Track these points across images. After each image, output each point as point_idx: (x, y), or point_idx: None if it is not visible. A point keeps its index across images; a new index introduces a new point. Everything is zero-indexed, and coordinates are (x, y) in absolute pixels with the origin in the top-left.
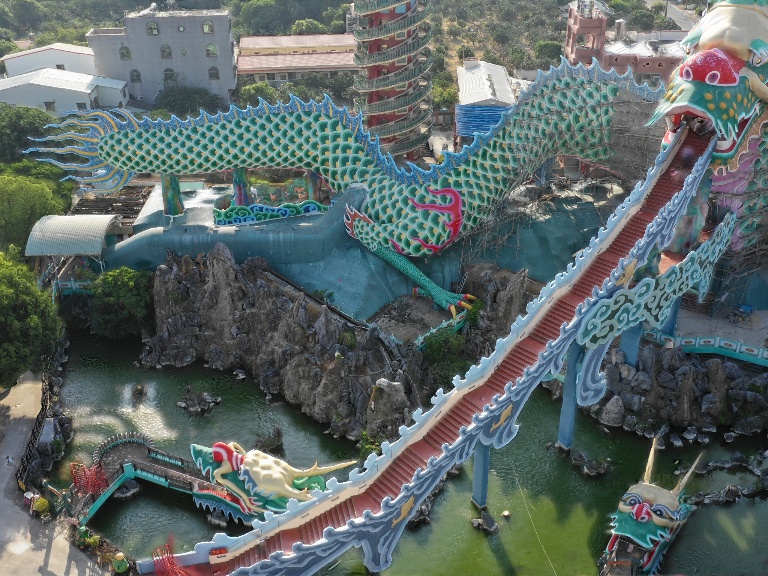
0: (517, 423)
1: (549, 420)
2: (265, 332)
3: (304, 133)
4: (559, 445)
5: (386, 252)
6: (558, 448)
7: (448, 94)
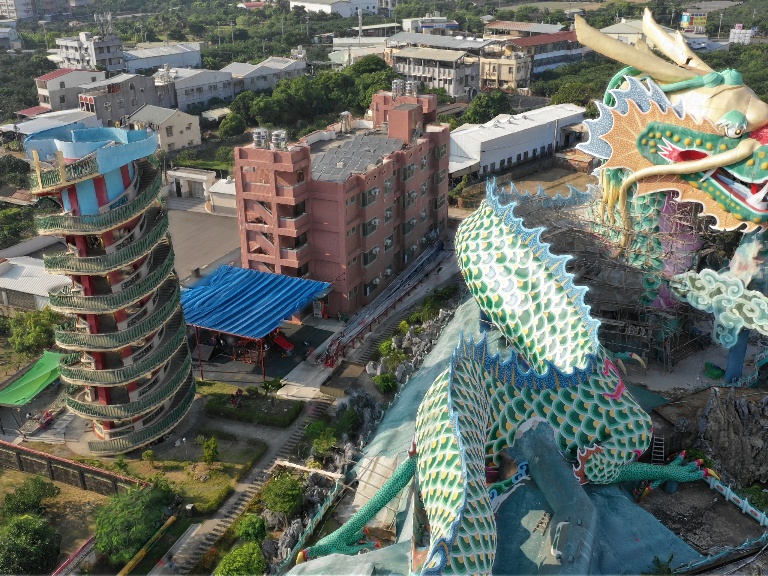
0: None
1: None
2: None
3: (478, 398)
4: None
5: (628, 470)
6: None
7: (49, 314)
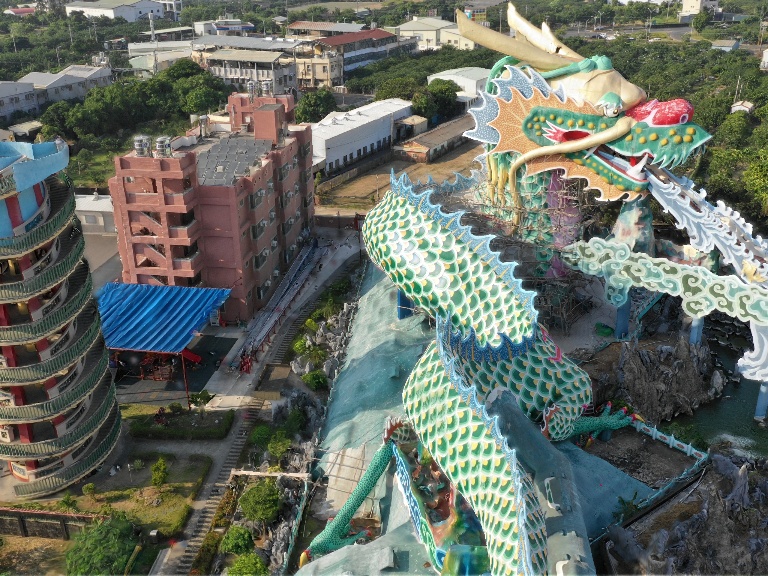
0: (741, 436)
1: (718, 424)
2: (712, 571)
3: (463, 374)
4: (763, 420)
5: None
6: (765, 422)
7: None
